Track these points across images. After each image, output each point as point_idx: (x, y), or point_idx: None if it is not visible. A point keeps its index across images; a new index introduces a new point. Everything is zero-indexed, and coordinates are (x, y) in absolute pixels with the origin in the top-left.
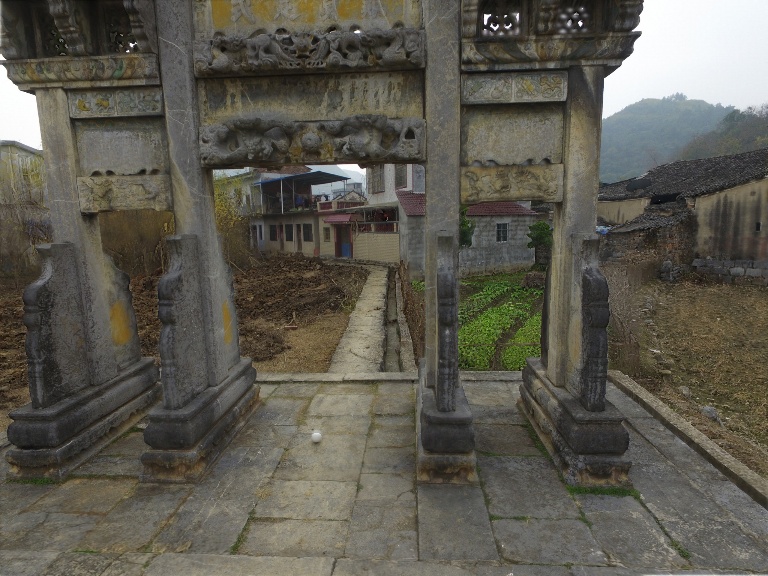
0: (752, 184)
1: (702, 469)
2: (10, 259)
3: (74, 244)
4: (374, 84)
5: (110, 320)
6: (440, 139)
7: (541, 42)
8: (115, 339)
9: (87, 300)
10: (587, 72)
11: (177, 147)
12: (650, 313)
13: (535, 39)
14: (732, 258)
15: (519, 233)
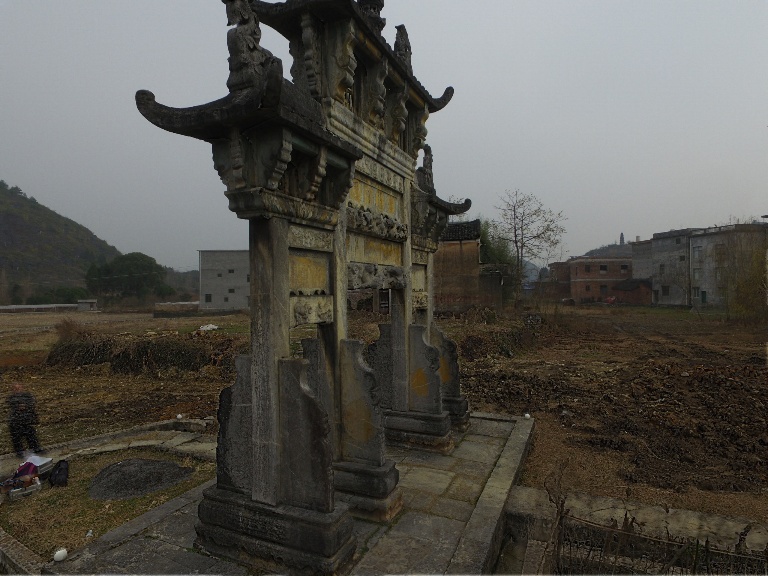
0: None
1: None
2: None
3: None
4: None
5: None
6: None
7: None
8: None
9: None
10: None
11: None
12: None
13: None
14: None
15: None
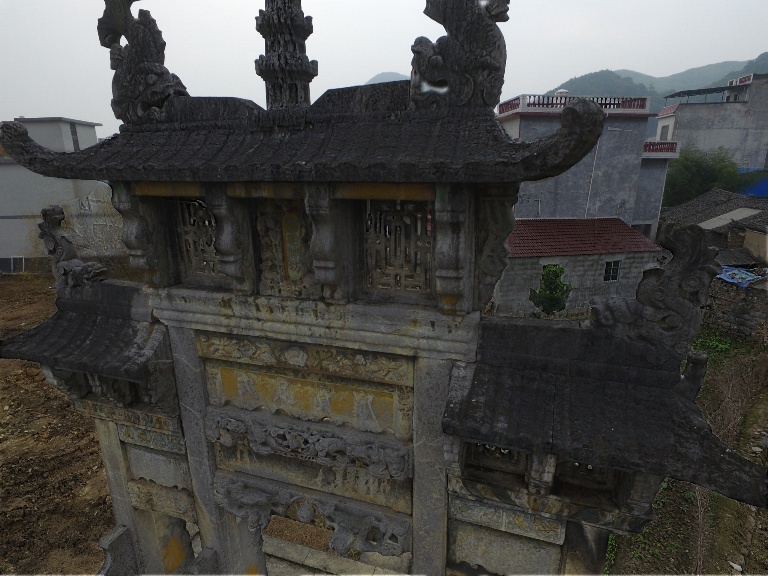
0: None
1: None
2: None
3: (129, 528)
4: (365, 474)
5: (165, 558)
6: (425, 543)
7: (534, 496)
8: (170, 569)
9: (141, 566)
10: (588, 530)
11: (198, 485)
12: (761, 461)
13: (527, 493)
14: None
15: (633, 271)
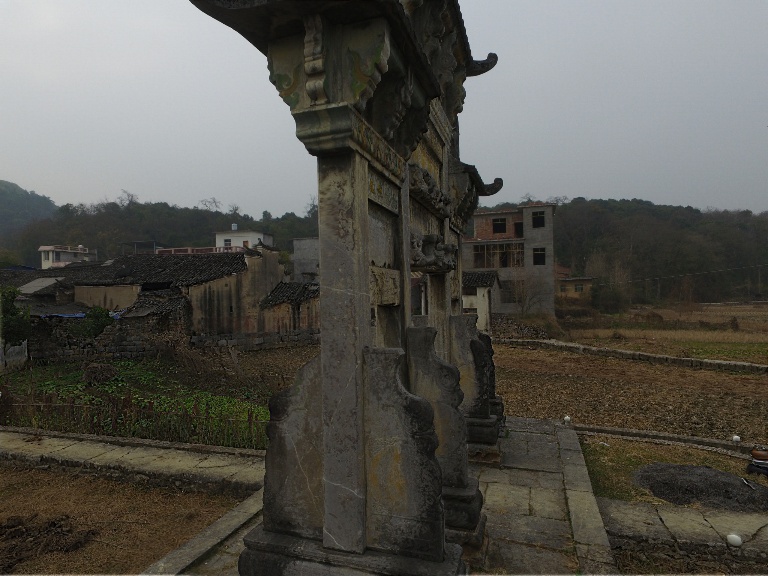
0: (225, 279)
1: None
2: None
3: None
4: (434, 223)
5: None
6: None
7: (459, 220)
8: None
9: None
10: None
11: None
12: None
13: (459, 218)
14: (218, 333)
15: None
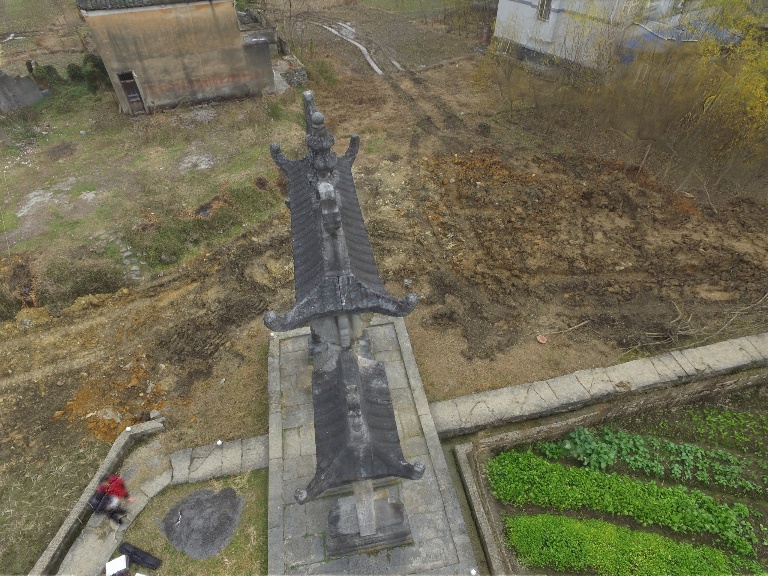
0: None
1: None
2: (550, 111)
3: None
4: None
5: None
6: None
7: None
8: None
9: None
10: None
11: None
12: None
13: None
14: None
15: None
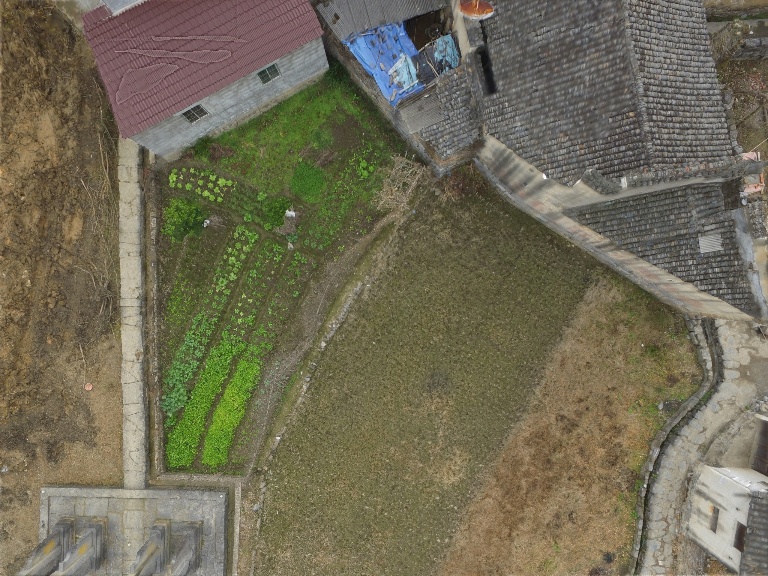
0: None
1: (220, 559)
2: None
3: None
4: None
5: None
6: None
7: None
8: None
9: None
10: None
11: None
12: (320, 356)
13: None
14: (500, 180)
15: (296, 61)
